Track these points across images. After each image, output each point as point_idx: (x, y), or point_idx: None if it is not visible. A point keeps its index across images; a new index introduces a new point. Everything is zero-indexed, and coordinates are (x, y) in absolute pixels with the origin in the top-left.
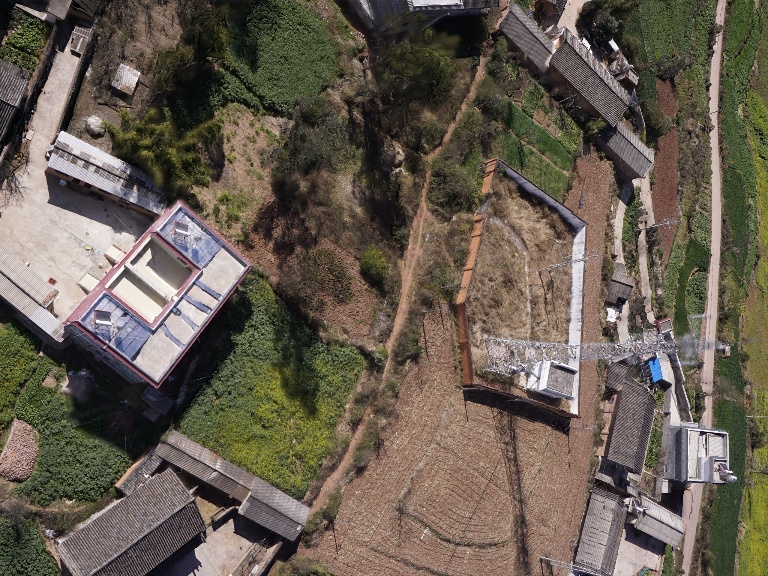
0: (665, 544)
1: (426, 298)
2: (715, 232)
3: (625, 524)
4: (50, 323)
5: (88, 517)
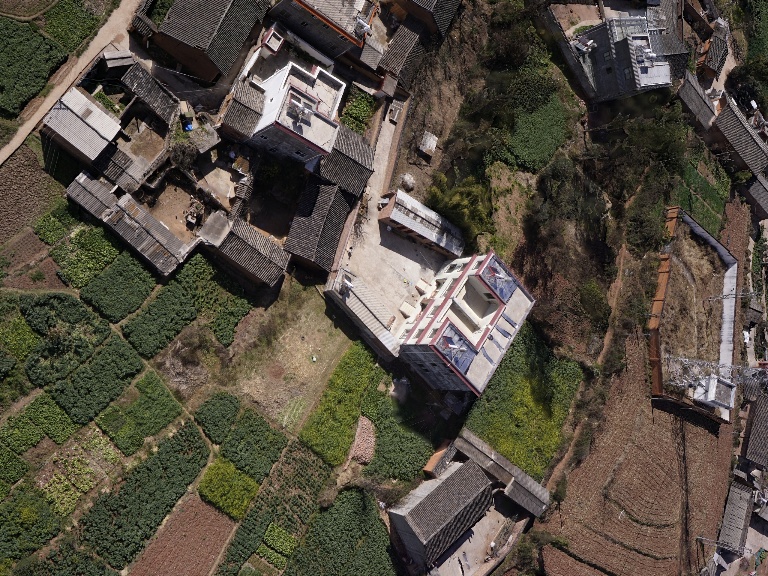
0: None
1: (629, 323)
2: None
3: None
4: (391, 342)
5: (407, 493)
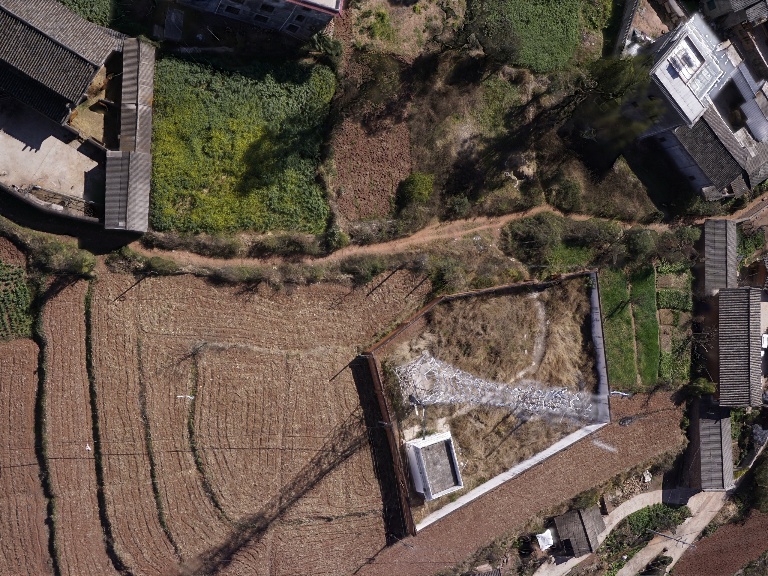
0: None
1: None
2: None
3: None
4: None
5: None
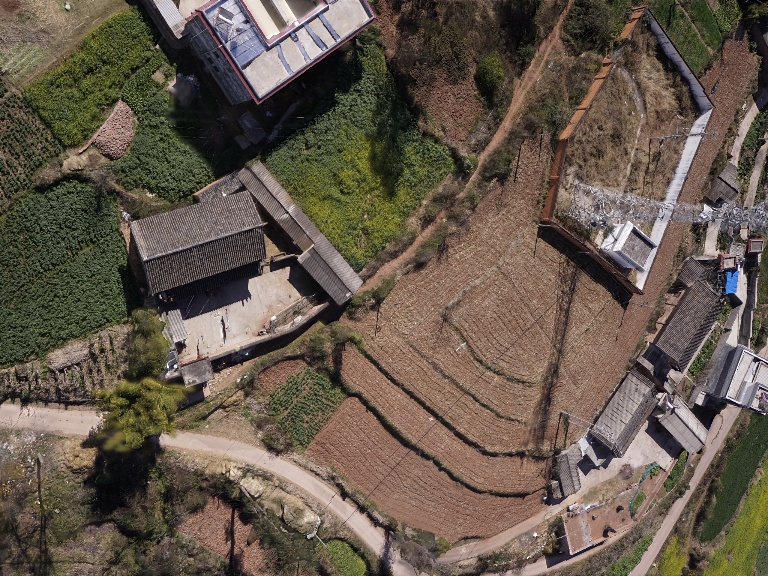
0: (682, 450)
1: (531, 123)
2: None
3: (650, 416)
4: (173, 16)
5: None
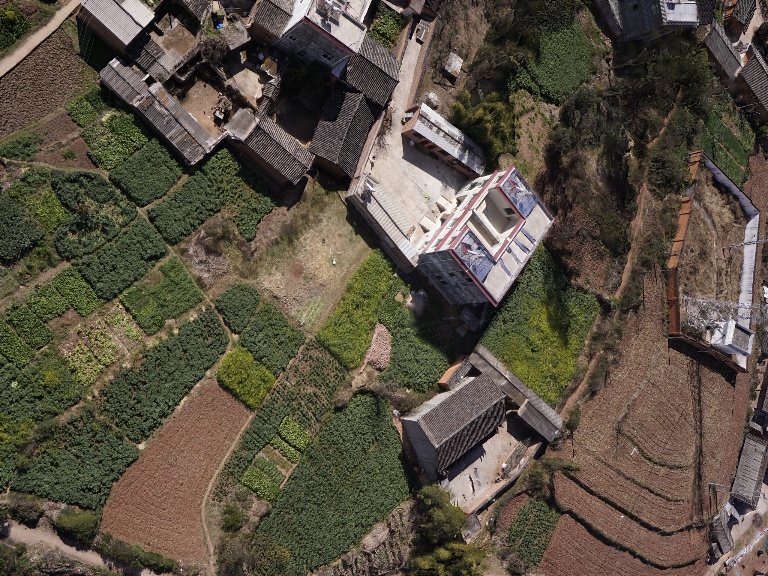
0: None
1: (648, 261)
2: None
3: None
4: (410, 251)
5: (421, 404)
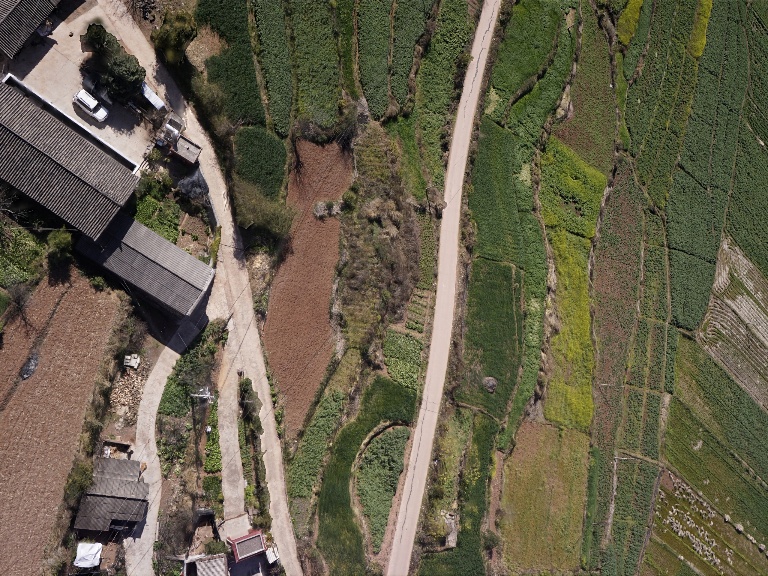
0: None
1: None
2: (436, 362)
3: None
4: None
5: None
